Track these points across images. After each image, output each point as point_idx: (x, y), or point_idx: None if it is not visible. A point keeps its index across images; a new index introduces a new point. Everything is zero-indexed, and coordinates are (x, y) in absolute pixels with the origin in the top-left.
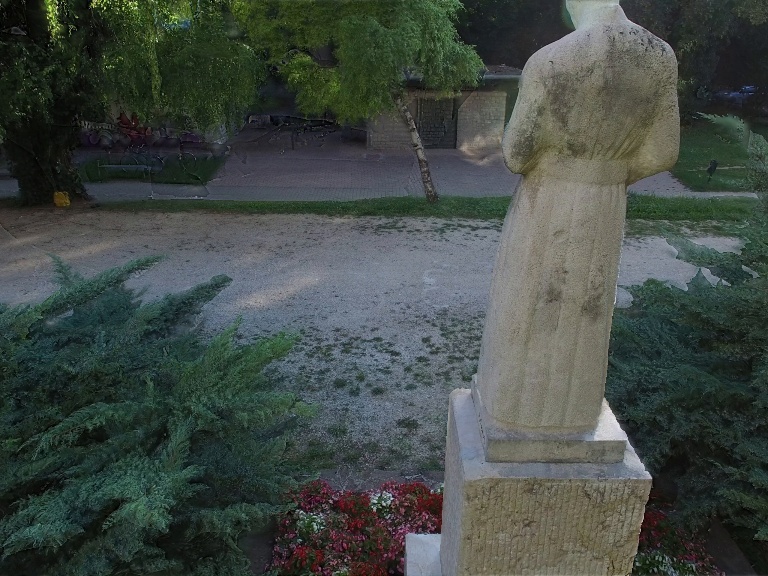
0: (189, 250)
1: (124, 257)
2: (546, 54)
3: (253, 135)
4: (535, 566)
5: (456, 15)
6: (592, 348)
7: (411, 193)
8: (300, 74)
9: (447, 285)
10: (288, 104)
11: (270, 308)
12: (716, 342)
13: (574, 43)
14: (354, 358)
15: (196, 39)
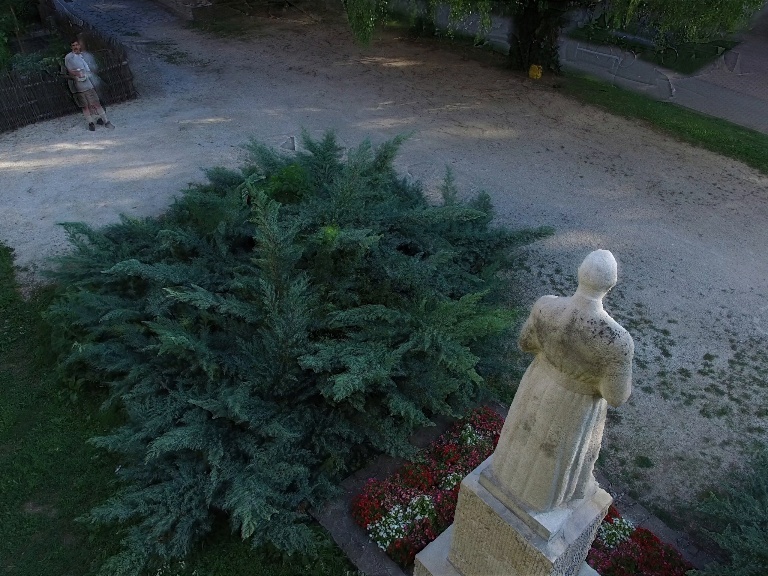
0: (592, 165)
1: (538, 153)
2: (542, 304)
3: None
4: (489, 552)
5: None
6: (544, 470)
7: None
8: None
9: None
10: None
11: None
12: None
13: (556, 308)
14: None
15: None
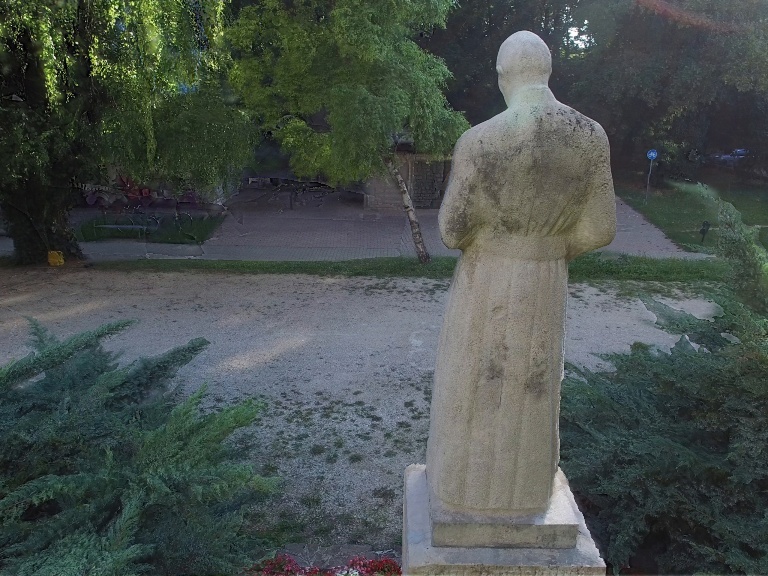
0: (177, 310)
1: (112, 317)
2: (477, 134)
3: (253, 195)
4: None
5: (446, 83)
6: (538, 427)
7: (403, 253)
8: (294, 138)
9: (434, 347)
10: (282, 167)
11: (253, 370)
12: (696, 411)
13: (504, 123)
14: (334, 423)
15: (193, 105)
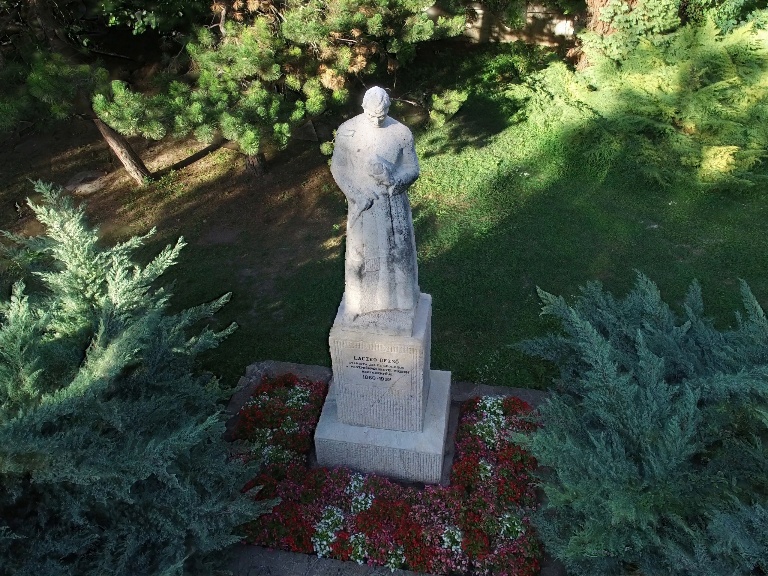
0: None
1: None
2: None
3: None
4: None
5: None
6: None
7: None
8: None
9: None
10: None
11: None
12: None
13: None
14: None
15: None
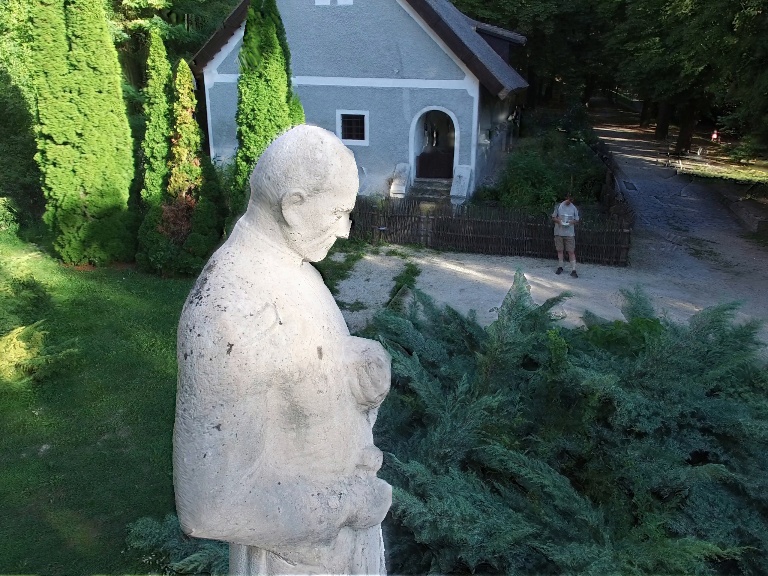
0: None
1: None
2: None
3: None
4: None
5: None
6: None
7: None
8: None
9: None
10: None
11: None
12: None
13: None
14: None
15: None
